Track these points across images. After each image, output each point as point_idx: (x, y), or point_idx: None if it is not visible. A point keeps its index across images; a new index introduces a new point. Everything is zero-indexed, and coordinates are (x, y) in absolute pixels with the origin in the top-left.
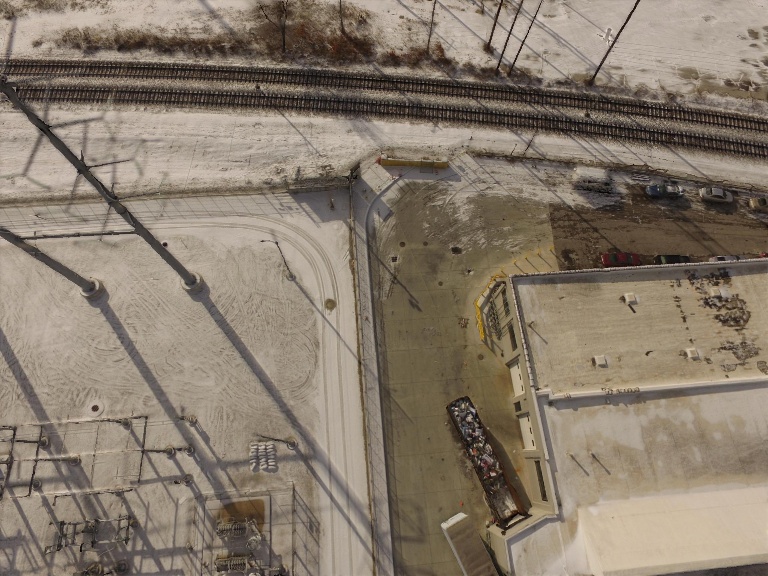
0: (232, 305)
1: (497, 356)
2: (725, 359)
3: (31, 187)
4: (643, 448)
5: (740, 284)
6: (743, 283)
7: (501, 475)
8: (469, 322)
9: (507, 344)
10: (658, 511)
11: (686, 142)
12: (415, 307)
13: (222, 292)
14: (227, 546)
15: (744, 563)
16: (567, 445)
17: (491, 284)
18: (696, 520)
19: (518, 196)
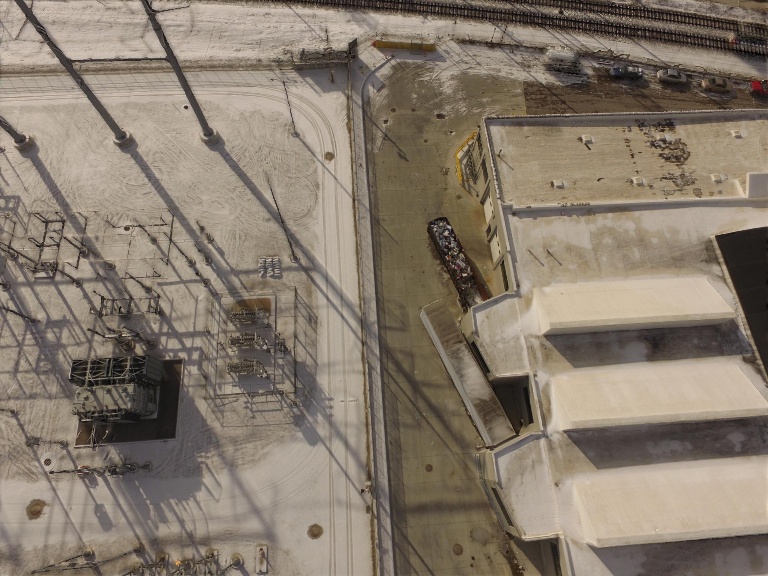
0: (244, 154)
1: (473, 196)
2: (665, 186)
3: None
4: (591, 247)
5: (683, 131)
6: (685, 130)
7: (472, 278)
8: (450, 171)
9: (481, 183)
10: (600, 290)
11: (648, 35)
12: (403, 158)
13: (235, 144)
14: (239, 331)
15: (667, 320)
16: (526, 244)
17: (470, 141)
18: (631, 296)
19: (496, 75)
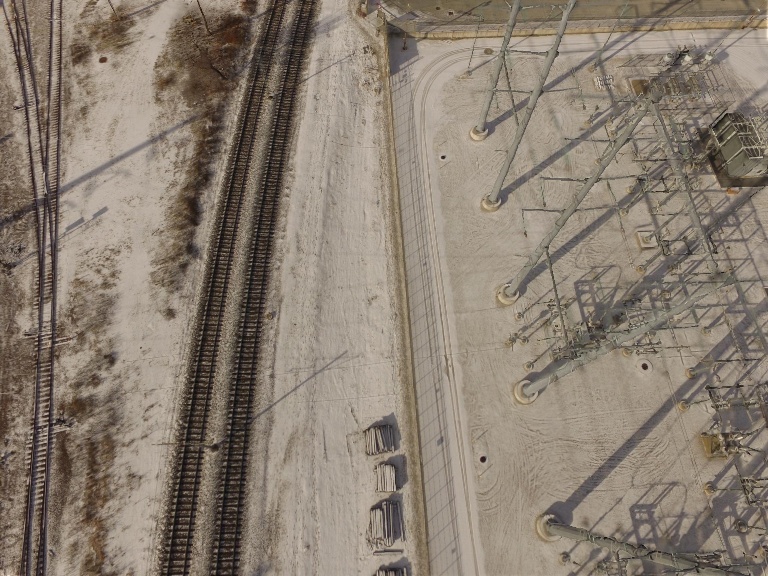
0: None
1: None
2: None
3: (382, 278)
4: None
5: None
6: None
7: None
8: None
9: None
10: None
11: None
12: (488, 4)
13: None
14: None
15: None
16: None
17: None
18: None
19: None
